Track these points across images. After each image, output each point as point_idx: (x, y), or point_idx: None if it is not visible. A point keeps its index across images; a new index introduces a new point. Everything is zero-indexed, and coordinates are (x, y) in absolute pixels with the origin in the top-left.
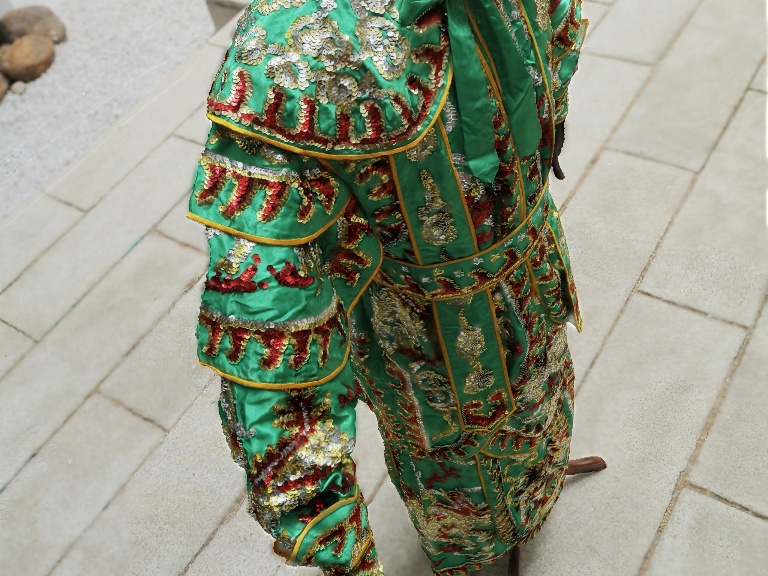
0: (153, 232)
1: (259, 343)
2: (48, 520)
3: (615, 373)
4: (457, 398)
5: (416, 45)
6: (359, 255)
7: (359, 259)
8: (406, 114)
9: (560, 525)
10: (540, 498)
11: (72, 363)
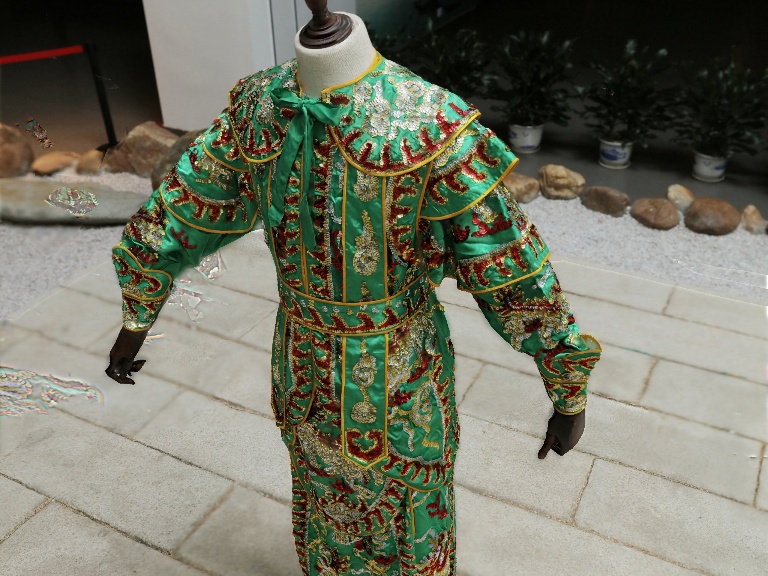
0: (655, 359)
1: None
2: None
3: None
4: None
5: (276, 119)
6: None
7: None
8: None
9: None
10: None
11: (507, 344)
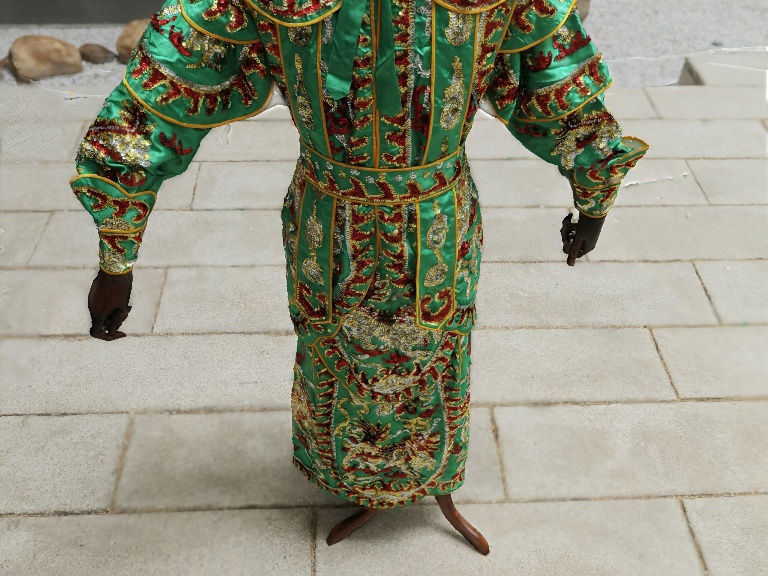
0: None
1: (139, 59)
2: (206, 244)
3: (580, 520)
4: (297, 270)
5: None
6: (249, 83)
7: (249, 87)
8: (290, 1)
9: (410, 545)
10: (374, 470)
11: None
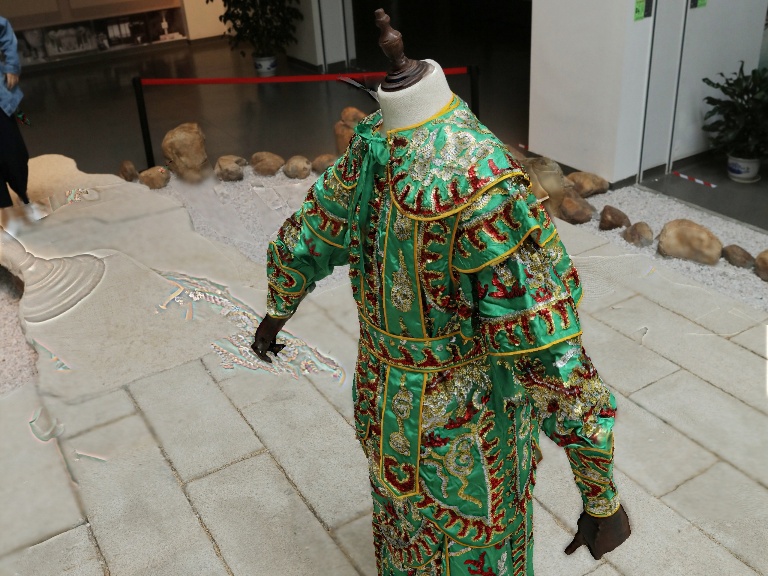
0: None
1: None
2: None
3: None
4: None
5: None
6: None
7: None
8: None
9: None
10: None
11: (759, 447)
